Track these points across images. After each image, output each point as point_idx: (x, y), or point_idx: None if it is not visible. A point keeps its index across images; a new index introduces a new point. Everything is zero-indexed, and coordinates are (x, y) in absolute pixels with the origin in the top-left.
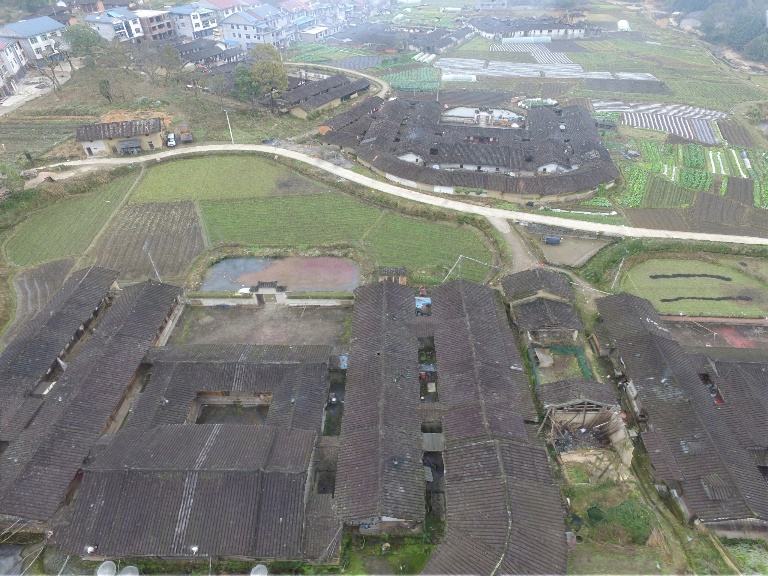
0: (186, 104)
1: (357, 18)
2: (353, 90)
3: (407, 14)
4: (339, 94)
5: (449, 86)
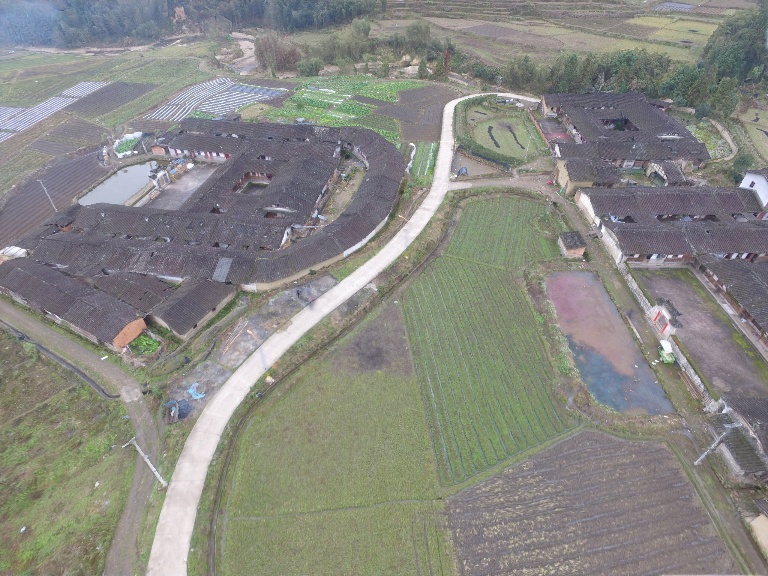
0: None
1: None
2: None
3: None
4: None
5: None
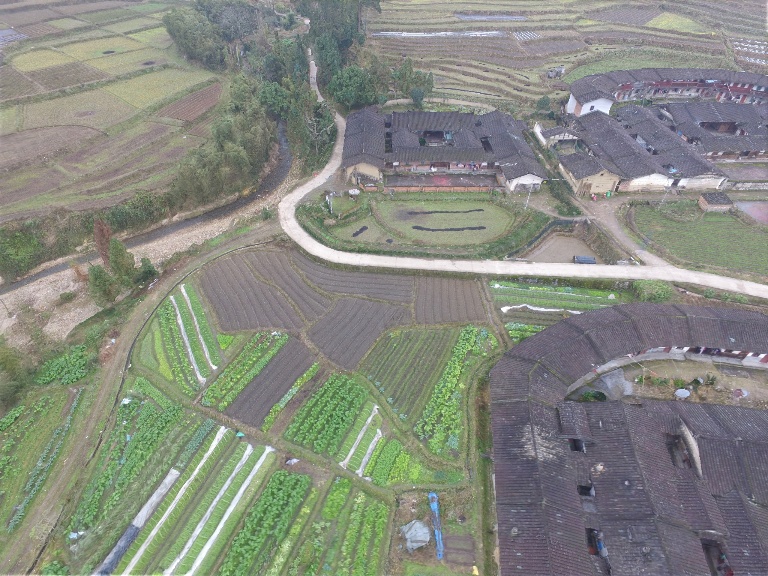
0: None
1: None
2: None
3: None
4: None
5: None
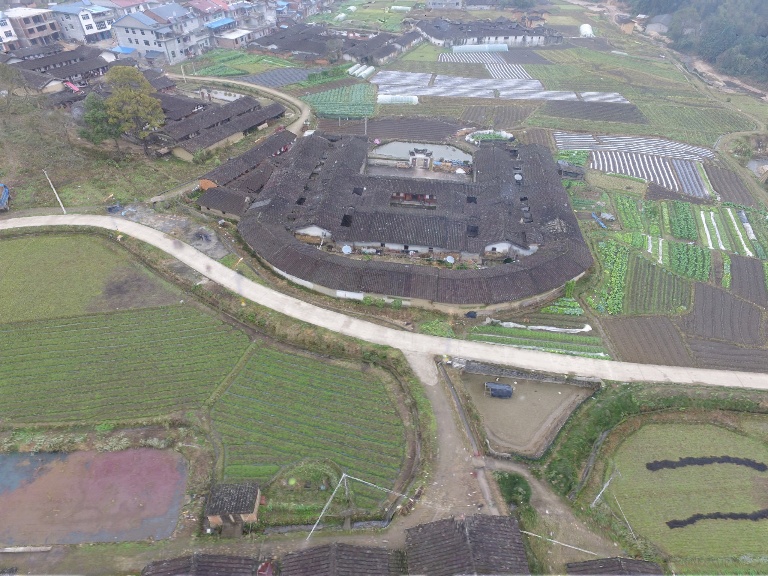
0: (25, 145)
1: (289, 19)
2: (261, 120)
3: (350, 13)
4: (241, 126)
5: (385, 111)
